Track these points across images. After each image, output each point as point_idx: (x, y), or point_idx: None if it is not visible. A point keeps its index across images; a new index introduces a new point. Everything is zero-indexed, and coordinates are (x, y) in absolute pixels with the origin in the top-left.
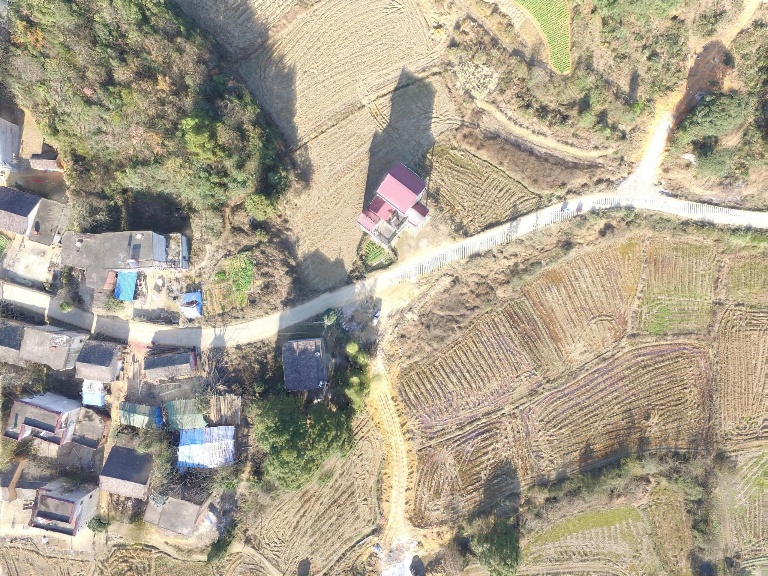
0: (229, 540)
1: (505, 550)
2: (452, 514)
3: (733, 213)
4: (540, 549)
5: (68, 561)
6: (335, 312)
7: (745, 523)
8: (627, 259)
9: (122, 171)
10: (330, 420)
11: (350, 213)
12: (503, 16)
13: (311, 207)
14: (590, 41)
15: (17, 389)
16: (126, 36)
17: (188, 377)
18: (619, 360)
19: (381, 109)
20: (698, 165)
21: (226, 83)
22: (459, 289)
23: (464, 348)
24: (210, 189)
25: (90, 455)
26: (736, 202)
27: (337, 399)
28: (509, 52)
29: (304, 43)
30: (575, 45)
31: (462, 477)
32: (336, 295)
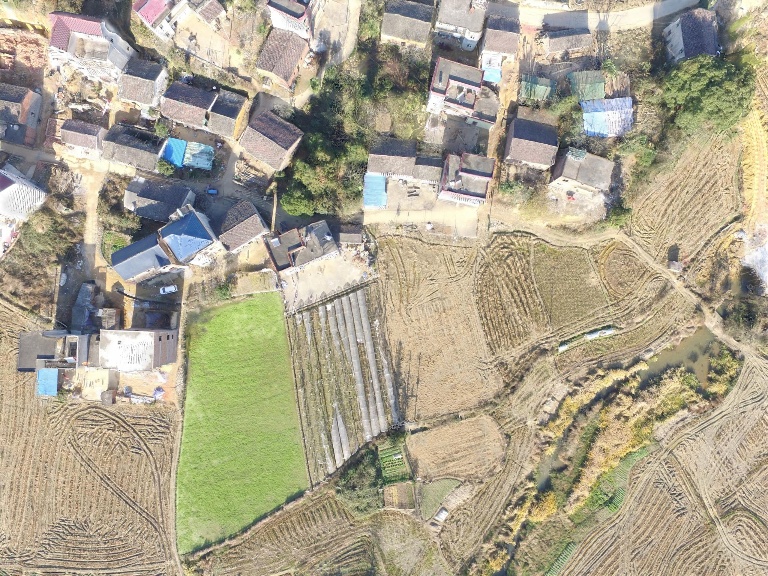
0: None
1: None
2: None
3: None
4: None
5: (451, 248)
6: None
7: None
8: None
9: None
10: None
11: None
12: None
13: None
14: None
15: (400, 79)
16: None
17: (579, 56)
18: None
19: None
20: None
21: None
22: None
23: None
24: None
25: (475, 141)
26: None
27: None
28: None
29: None
30: None
31: None
32: None
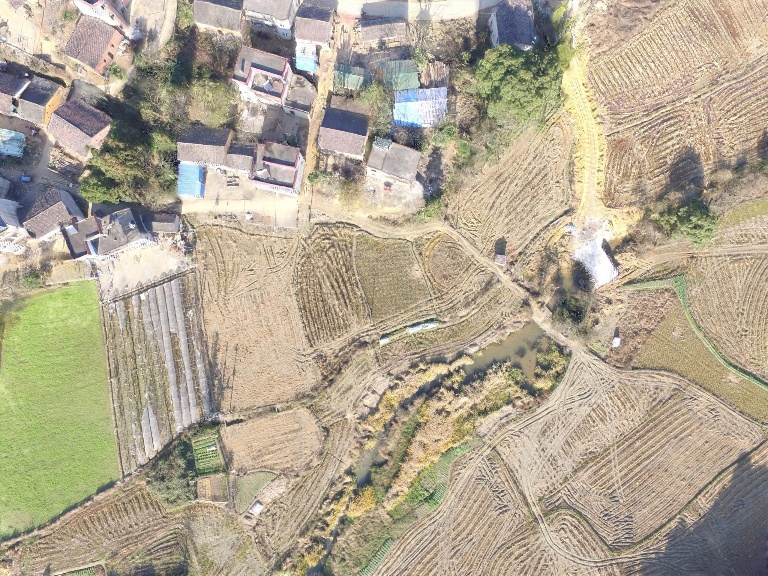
0: None
1: (703, 210)
2: (640, 196)
3: None
4: (722, 232)
5: (271, 238)
6: None
7: None
8: None
9: None
10: None
11: None
12: None
13: None
14: None
15: (221, 68)
16: None
17: (397, 46)
18: None
19: None
20: None
21: None
22: None
23: (649, 40)
24: None
25: (295, 131)
26: None
27: None
28: None
29: None
30: None
31: (649, 161)
32: None
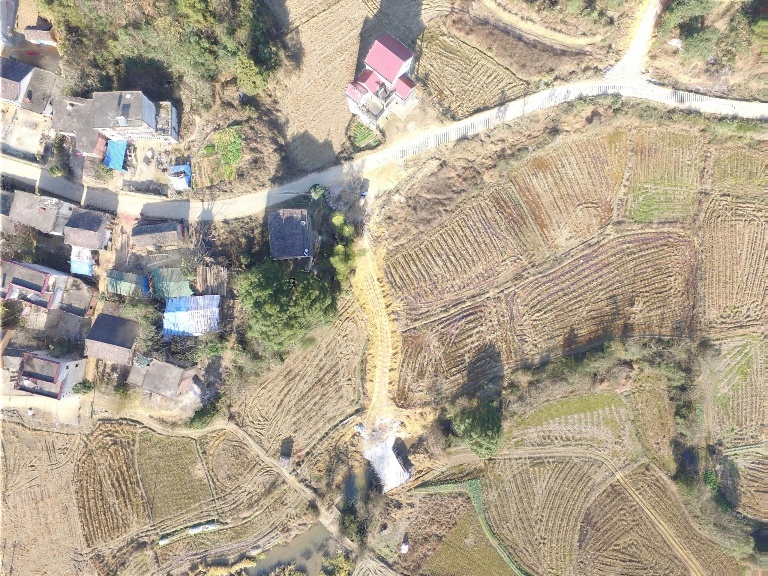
0: (213, 413)
1: (487, 424)
2: (435, 395)
3: (720, 102)
4: (523, 433)
5: (53, 434)
6: None
7: (728, 411)
8: (614, 148)
9: (114, 40)
10: (314, 280)
11: (339, 96)
12: None
13: (301, 89)
14: None
15: None
16: None
17: (175, 248)
18: (604, 247)
19: None
20: (685, 50)
21: None
22: (446, 173)
23: (450, 232)
24: (200, 54)
25: (77, 328)
26: (723, 92)
27: (323, 275)
28: None
29: None
30: None
31: (446, 359)
32: (324, 175)
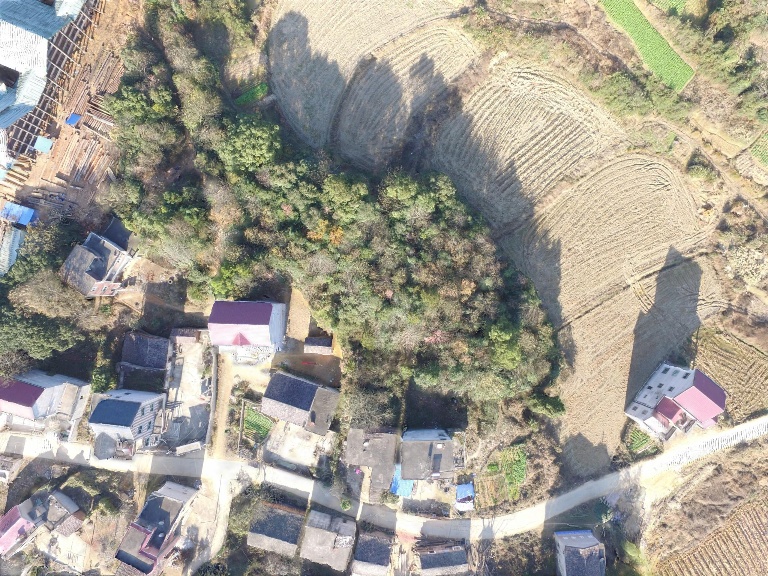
0: None
1: None
2: None
3: None
4: None
5: None
6: (600, 501)
7: None
8: None
9: (407, 365)
10: None
11: (613, 397)
12: None
13: (573, 389)
14: None
15: None
16: (421, 231)
17: None
18: None
19: (646, 289)
20: None
21: (514, 277)
22: (722, 478)
23: (724, 538)
24: (507, 394)
25: None
26: None
27: None
28: None
29: (568, 219)
30: None
31: None
32: (600, 483)
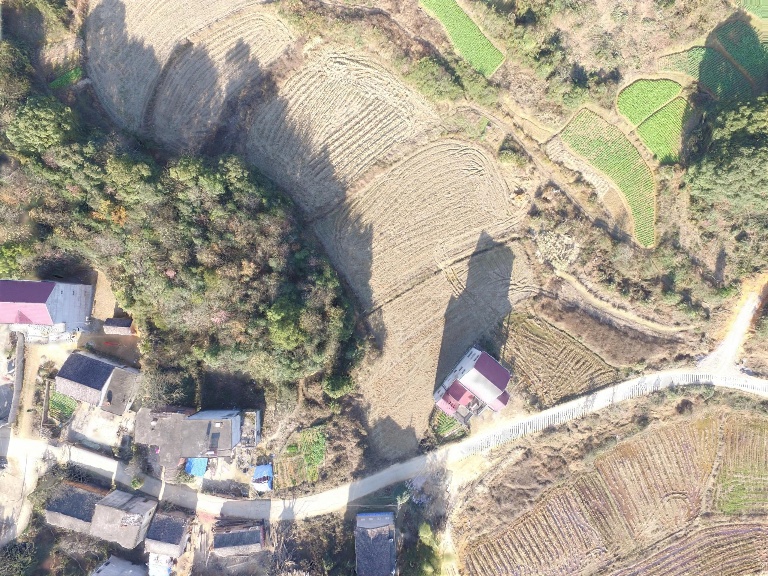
0: None
1: None
2: None
3: None
4: None
5: None
6: (405, 484)
7: None
8: (703, 435)
9: (199, 346)
10: None
11: (423, 380)
12: (587, 185)
13: (383, 373)
14: (677, 217)
15: None
16: (209, 213)
17: None
18: (692, 539)
19: (458, 274)
20: None
21: (307, 259)
22: (531, 462)
23: (534, 522)
24: (290, 375)
25: None
26: None
27: (405, 575)
28: (591, 221)
29: (381, 203)
30: (661, 220)
31: None
32: (406, 466)
